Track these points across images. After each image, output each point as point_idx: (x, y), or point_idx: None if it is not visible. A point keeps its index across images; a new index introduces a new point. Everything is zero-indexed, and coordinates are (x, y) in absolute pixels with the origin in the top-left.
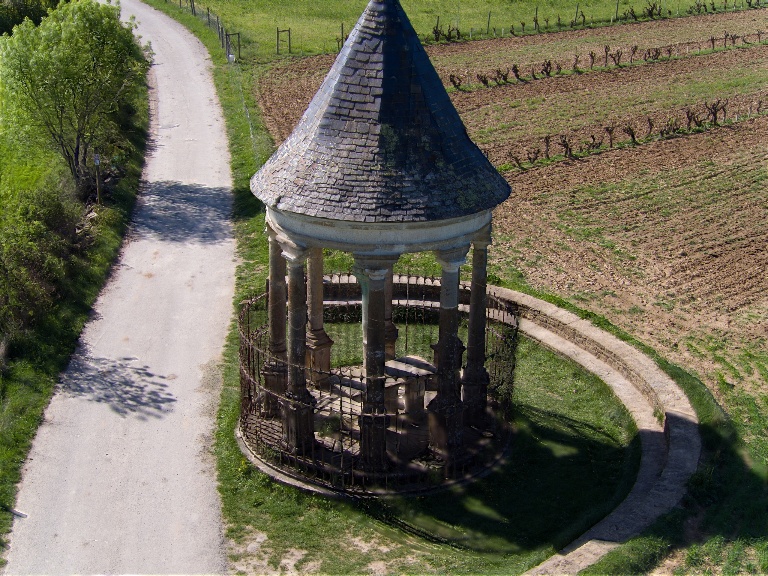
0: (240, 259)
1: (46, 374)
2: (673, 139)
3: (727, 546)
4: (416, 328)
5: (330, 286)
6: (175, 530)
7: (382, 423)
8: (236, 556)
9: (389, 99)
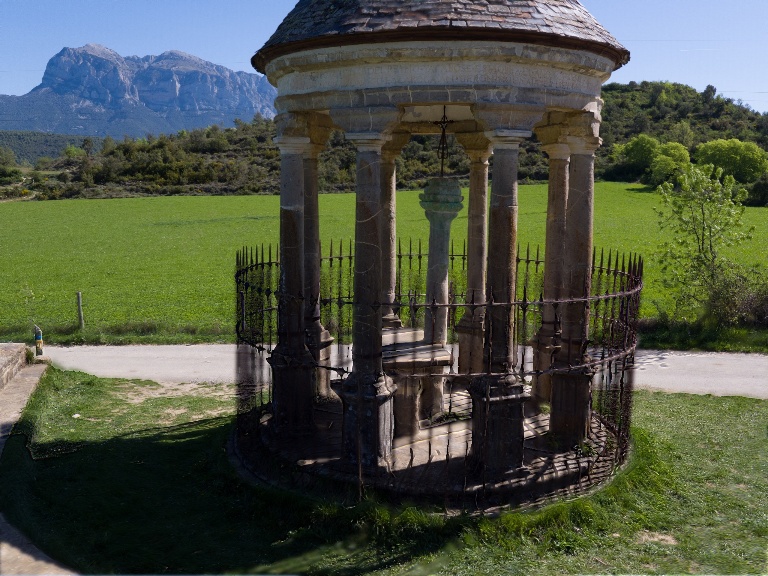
0: None
1: (620, 342)
2: None
3: None
4: None
5: None
6: None
7: None
8: None
9: None
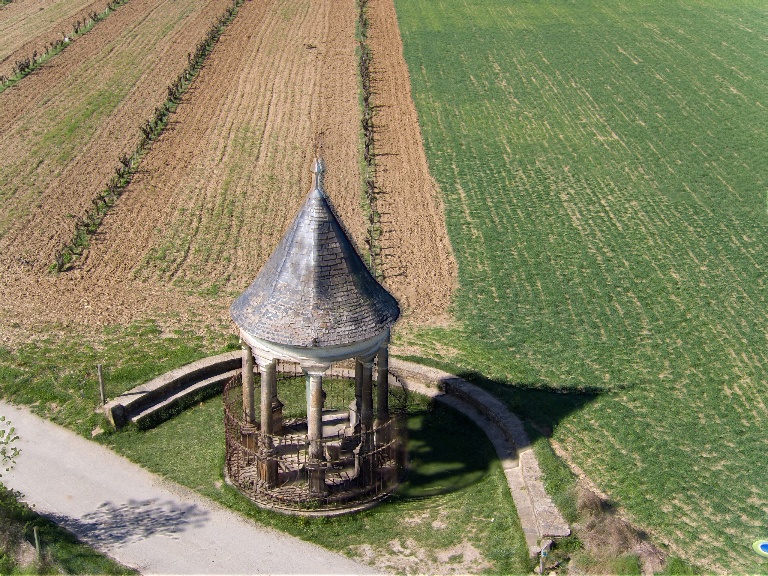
0: (22, 406)
1: (75, 545)
2: (124, 195)
3: (559, 428)
4: (220, 399)
5: (149, 394)
6: (325, 570)
7: None
8: (371, 562)
9: (347, 258)
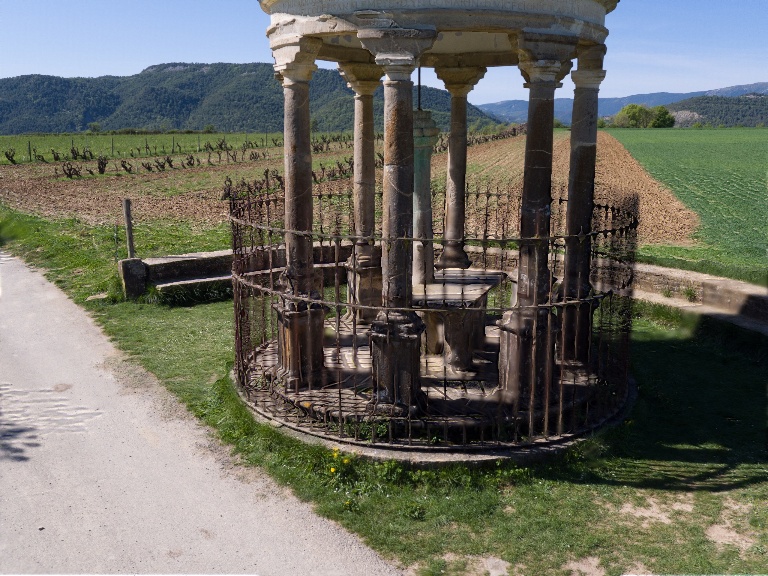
0: (41, 269)
1: None
2: (337, 180)
3: None
4: None
5: (202, 262)
6: None
7: (555, 324)
8: None
9: None
